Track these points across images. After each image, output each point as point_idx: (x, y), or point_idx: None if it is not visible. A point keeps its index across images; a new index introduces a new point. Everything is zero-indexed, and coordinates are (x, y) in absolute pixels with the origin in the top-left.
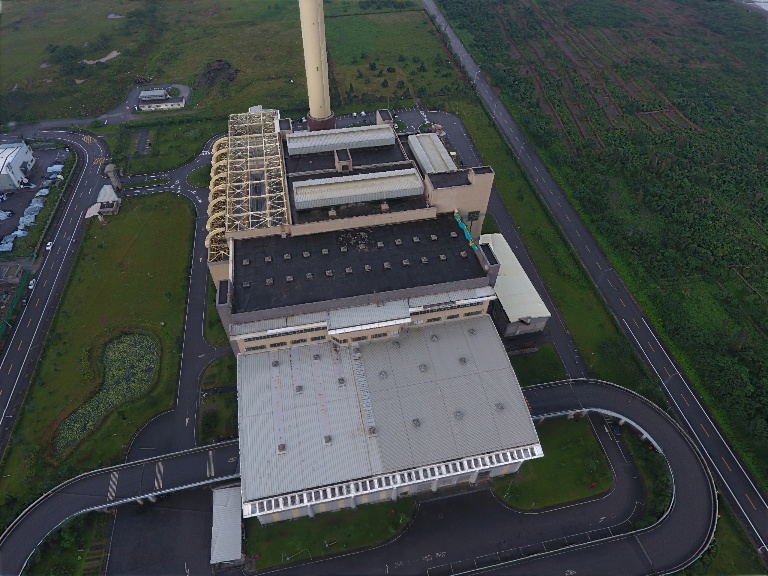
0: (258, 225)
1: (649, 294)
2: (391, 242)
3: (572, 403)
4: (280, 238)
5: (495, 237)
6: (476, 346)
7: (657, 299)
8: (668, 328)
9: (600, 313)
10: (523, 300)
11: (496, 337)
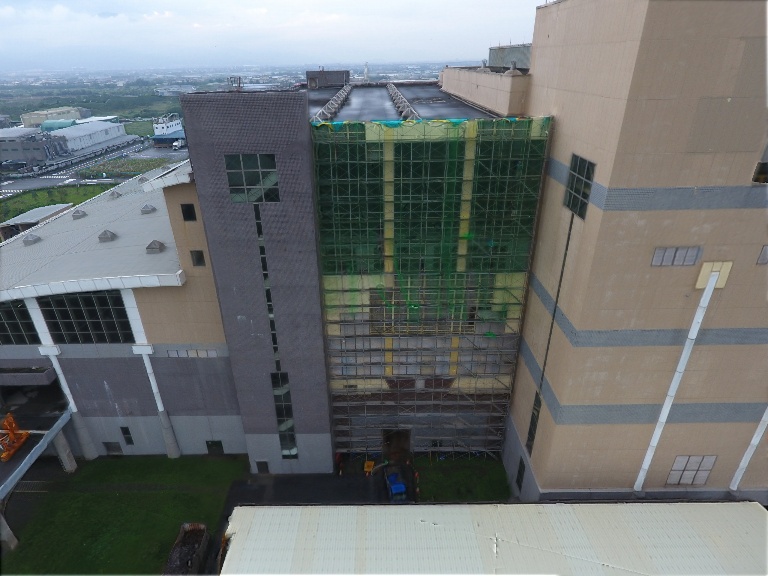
0: None
1: None
2: None
3: None
4: None
5: None
6: (118, 253)
7: None
8: None
9: None
10: None
11: (101, 276)
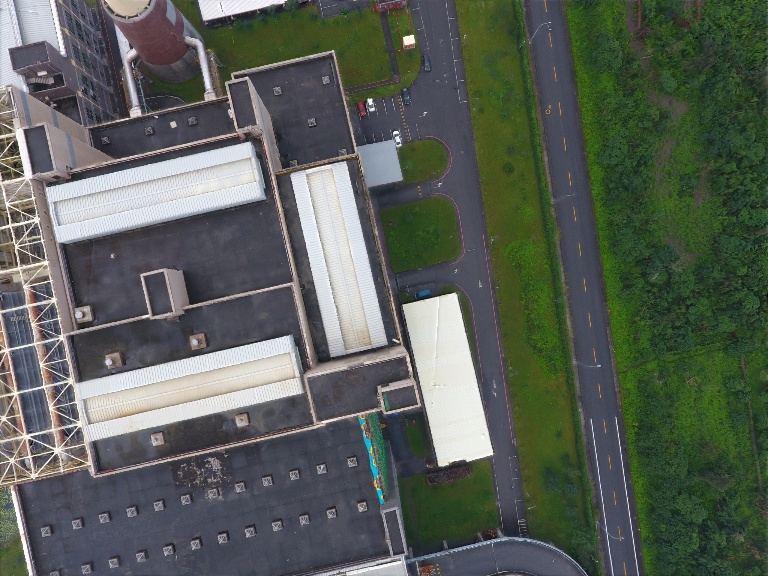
0: (44, 467)
1: (640, 378)
2: (256, 480)
3: (488, 568)
4: (87, 475)
5: (444, 304)
6: None
7: (646, 391)
8: (640, 444)
9: (564, 412)
10: (461, 432)
11: (402, 569)
